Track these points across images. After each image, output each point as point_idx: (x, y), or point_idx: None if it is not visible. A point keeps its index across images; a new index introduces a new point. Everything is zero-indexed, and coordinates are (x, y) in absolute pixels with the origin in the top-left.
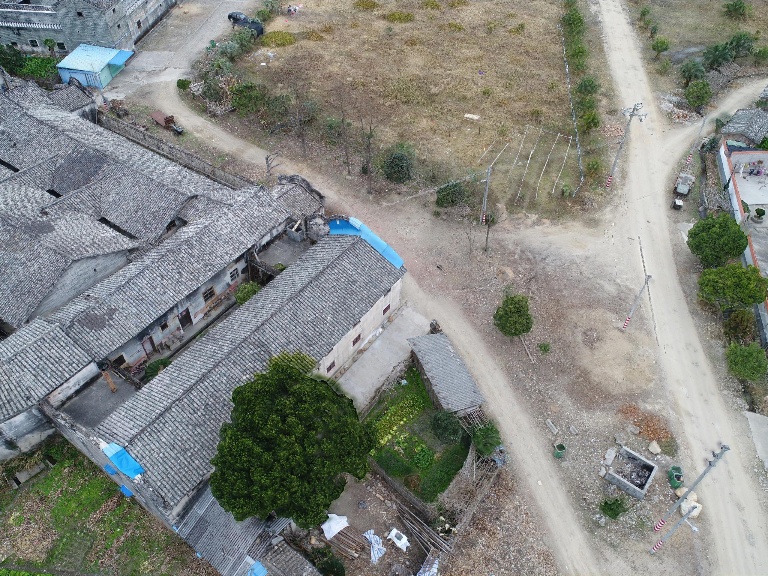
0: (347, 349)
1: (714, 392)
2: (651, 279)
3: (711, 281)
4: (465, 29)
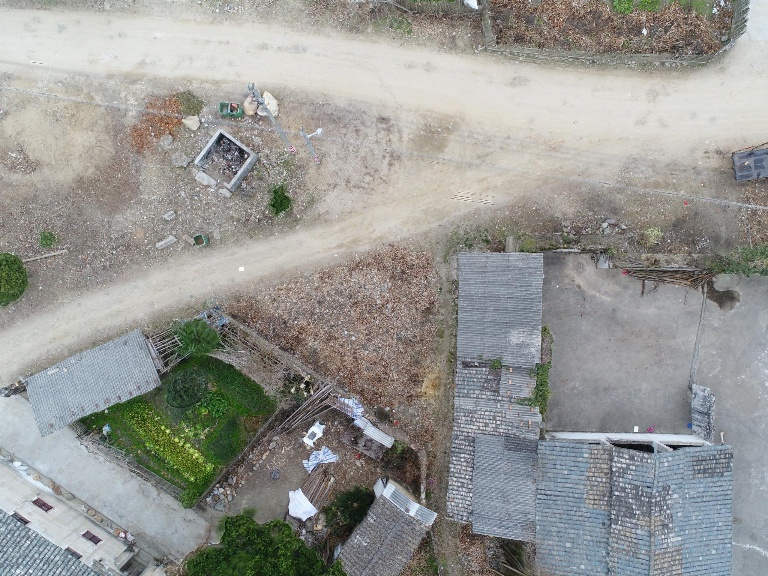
0: (60, 518)
1: (106, 20)
2: None
3: None
4: None
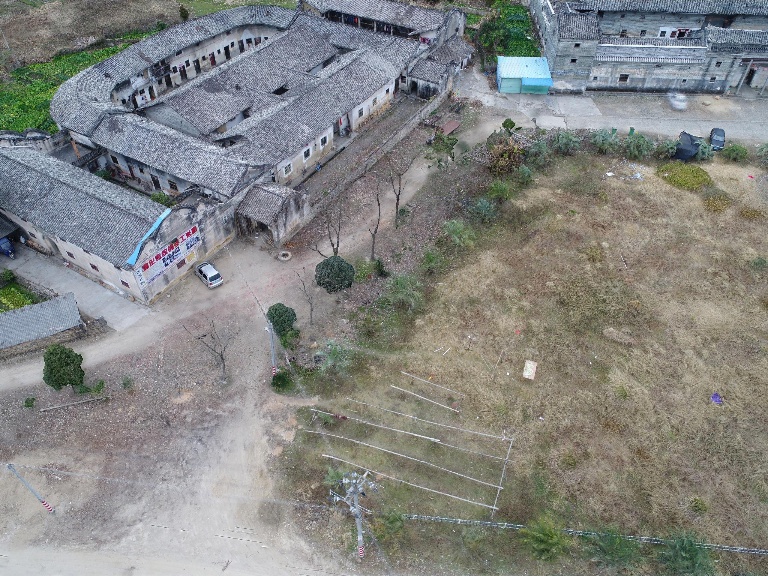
0: None
1: None
2: (131, 573)
3: None
4: None
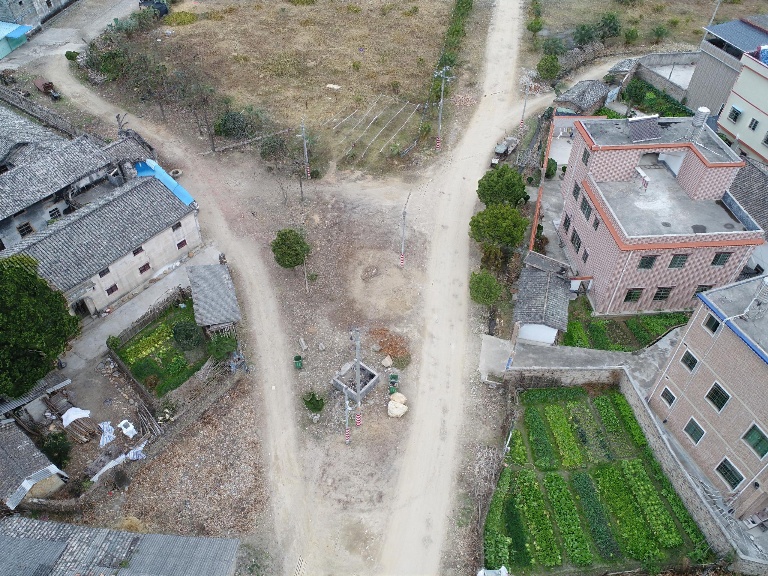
0: (132, 275)
1: (463, 319)
2: (445, 226)
3: (475, 221)
4: (362, 11)
